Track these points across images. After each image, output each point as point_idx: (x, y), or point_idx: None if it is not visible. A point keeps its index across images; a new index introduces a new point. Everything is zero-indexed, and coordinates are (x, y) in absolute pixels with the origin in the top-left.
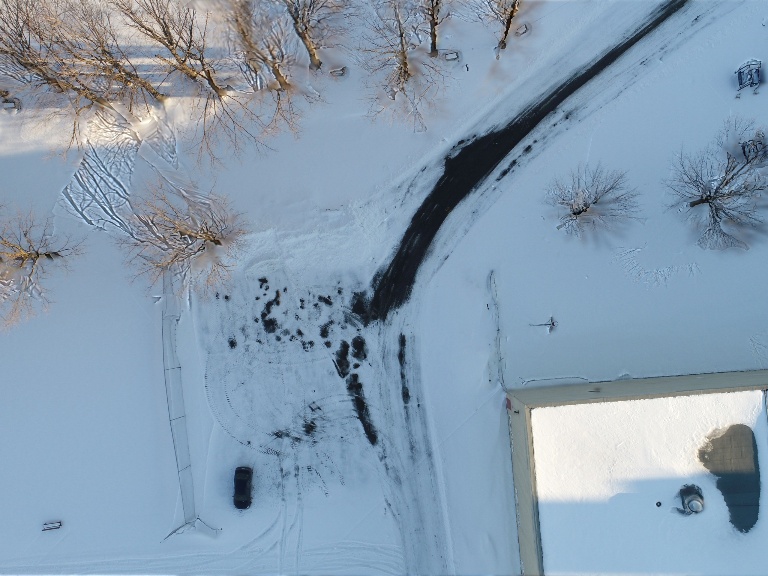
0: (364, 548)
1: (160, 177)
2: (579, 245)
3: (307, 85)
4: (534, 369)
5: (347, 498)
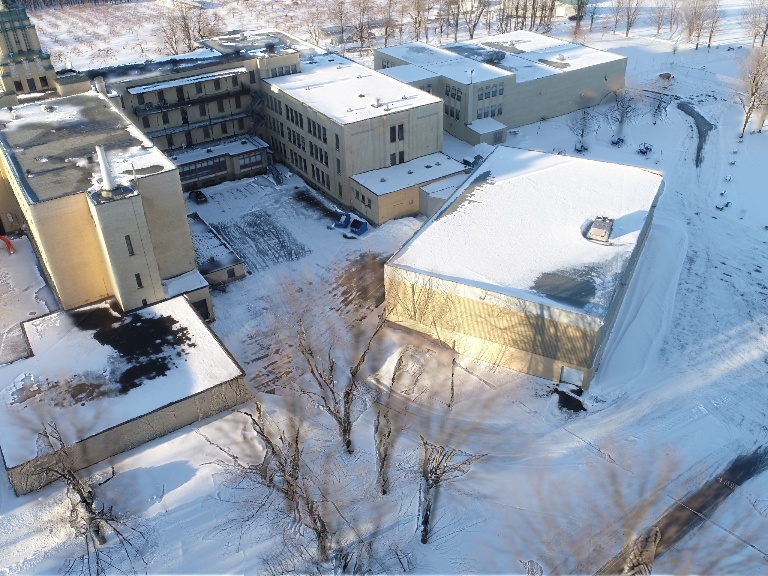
0: None
1: None
2: (643, 121)
3: None
4: (624, 92)
5: None
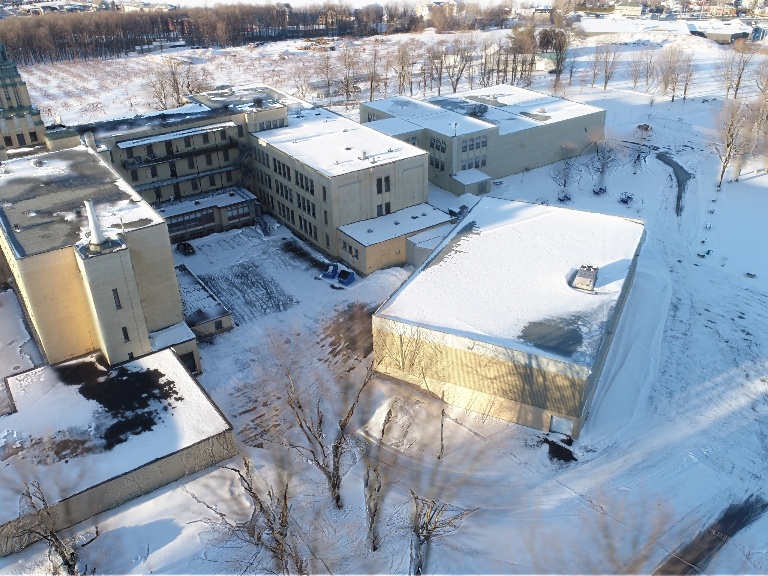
0: None
1: (761, 107)
2: (624, 171)
3: None
4: (604, 143)
5: None
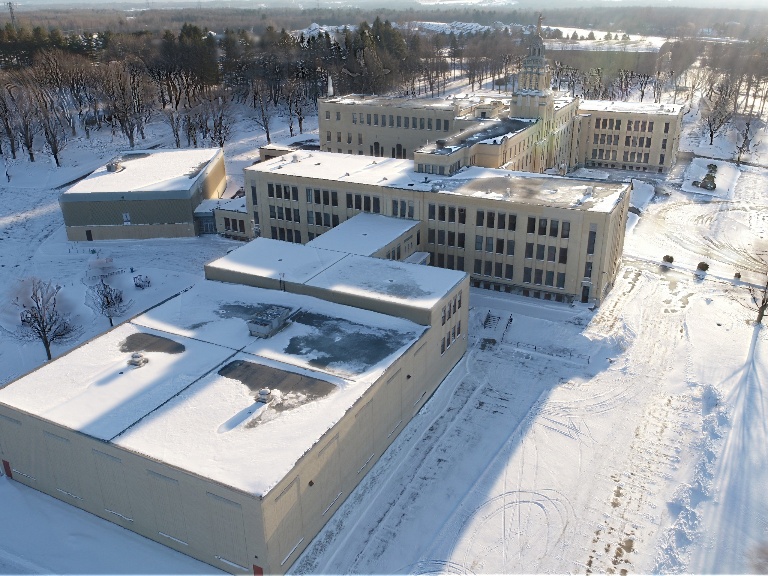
0: None
1: None
2: None
3: None
4: None
5: None
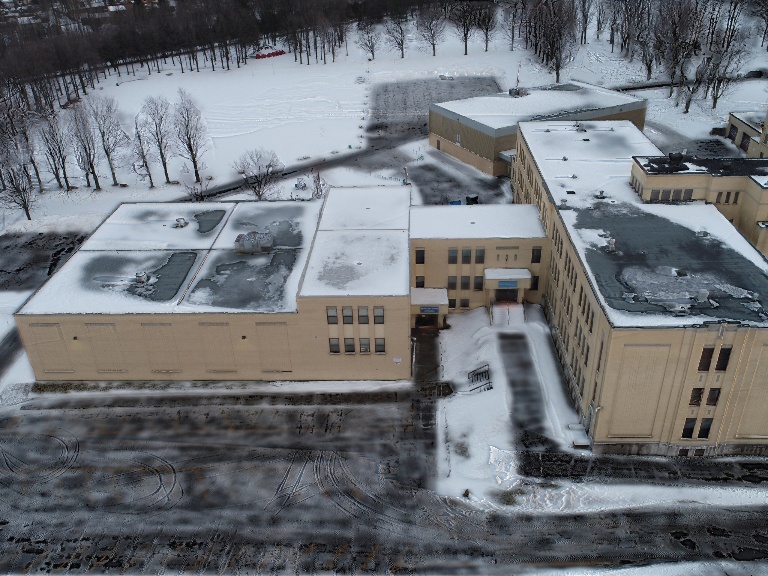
0: (8, 307)
1: None
2: None
3: (104, 174)
4: None
5: (16, 291)
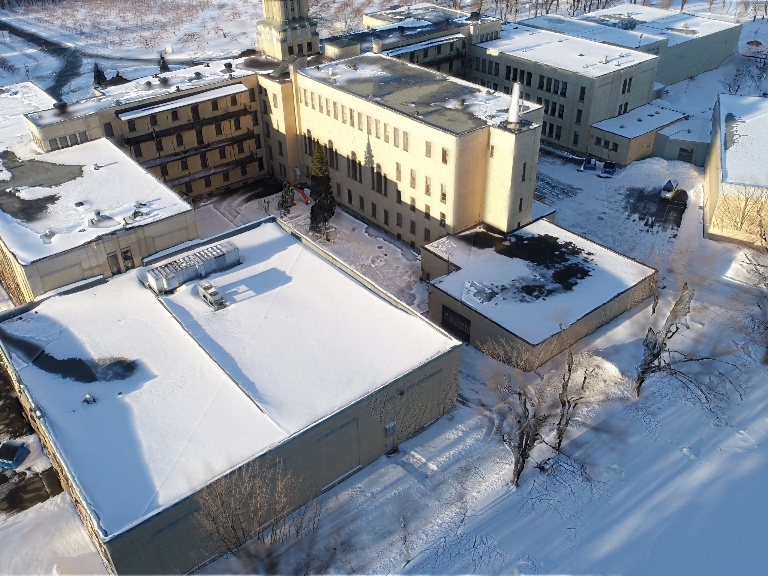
0: None
1: None
2: None
3: None
4: (739, 56)
5: None
